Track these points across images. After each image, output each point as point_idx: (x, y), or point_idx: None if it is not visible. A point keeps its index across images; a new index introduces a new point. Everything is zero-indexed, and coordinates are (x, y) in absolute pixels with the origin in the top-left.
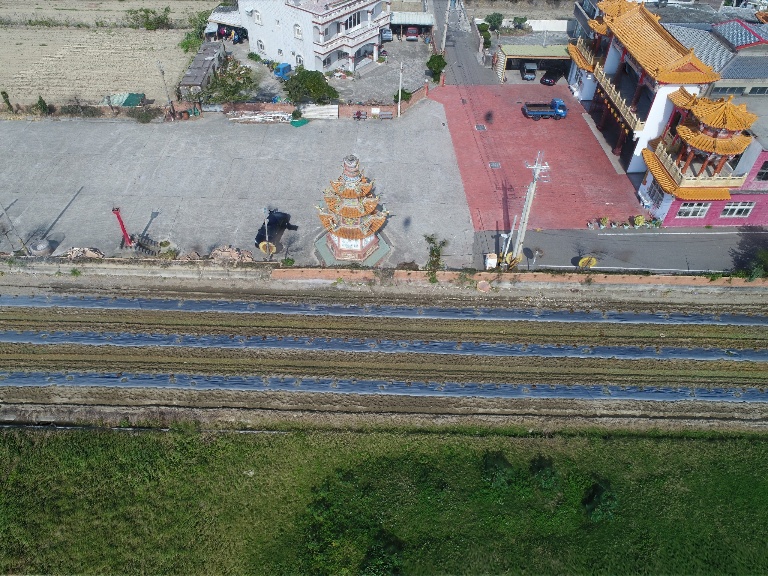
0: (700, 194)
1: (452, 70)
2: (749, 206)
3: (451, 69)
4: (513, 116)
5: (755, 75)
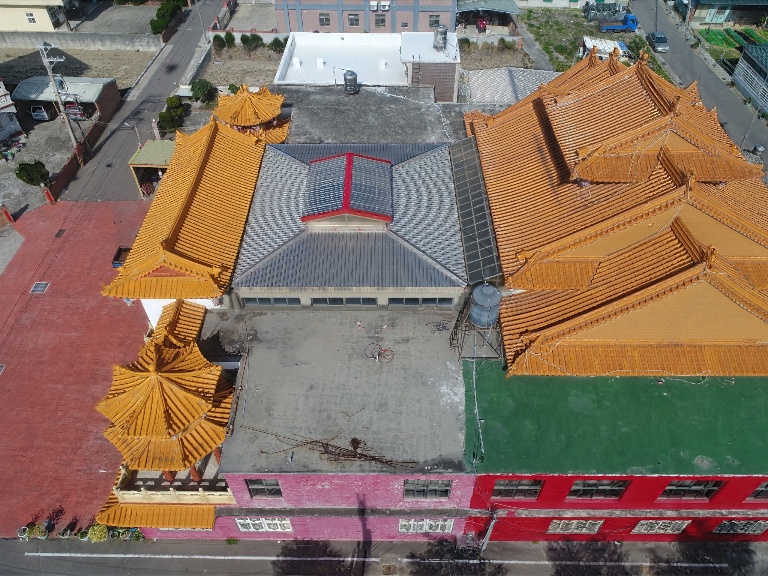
0: (159, 515)
1: (92, 173)
2: (281, 521)
3: (92, 171)
4: (106, 264)
5: (307, 280)
